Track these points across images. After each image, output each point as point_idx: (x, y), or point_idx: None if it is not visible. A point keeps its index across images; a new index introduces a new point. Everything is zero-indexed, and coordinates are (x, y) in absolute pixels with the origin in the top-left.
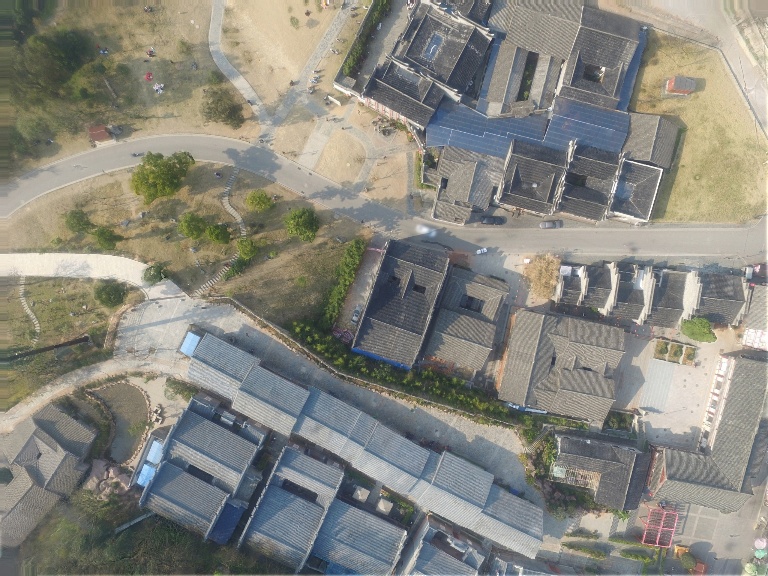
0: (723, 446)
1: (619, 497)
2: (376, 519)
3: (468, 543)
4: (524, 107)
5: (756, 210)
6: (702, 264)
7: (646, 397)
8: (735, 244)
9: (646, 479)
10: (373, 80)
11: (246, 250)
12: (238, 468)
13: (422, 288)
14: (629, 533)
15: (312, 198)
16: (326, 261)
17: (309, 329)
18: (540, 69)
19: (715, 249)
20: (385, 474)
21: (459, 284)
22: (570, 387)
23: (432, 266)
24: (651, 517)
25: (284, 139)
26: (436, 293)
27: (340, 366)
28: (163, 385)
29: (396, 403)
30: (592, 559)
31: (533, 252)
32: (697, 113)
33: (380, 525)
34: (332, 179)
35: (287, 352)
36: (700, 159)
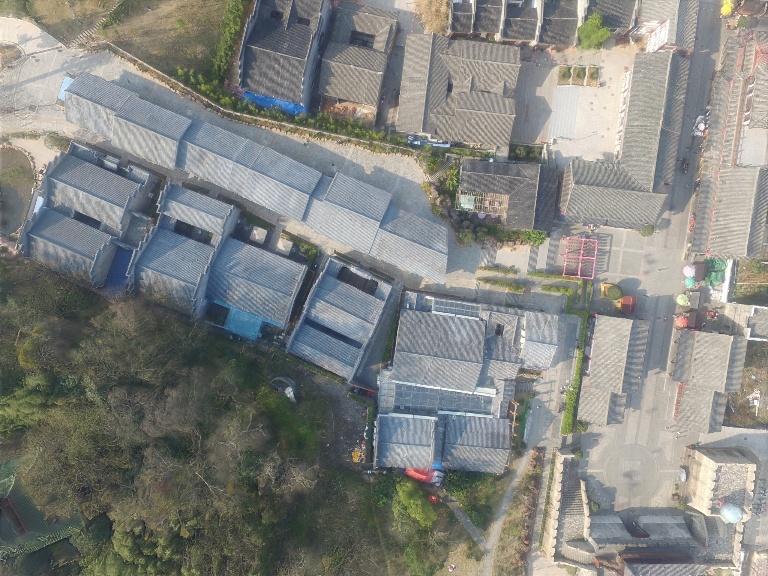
0: (631, 151)
1: (528, 215)
2: (274, 256)
3: (375, 277)
4: None
5: None
6: None
7: (554, 127)
8: None
9: (558, 200)
10: None
11: None
12: (121, 204)
13: (307, 21)
14: (551, 272)
15: None
16: (211, 14)
17: (193, 73)
18: None
19: None
20: (276, 198)
21: (346, 17)
22: (467, 106)
23: None
24: (570, 248)
25: None
26: (318, 17)
27: (228, 107)
28: (43, 137)
29: (288, 139)
30: (512, 296)
31: None
32: None
33: (279, 261)
34: None
35: (171, 95)
36: None
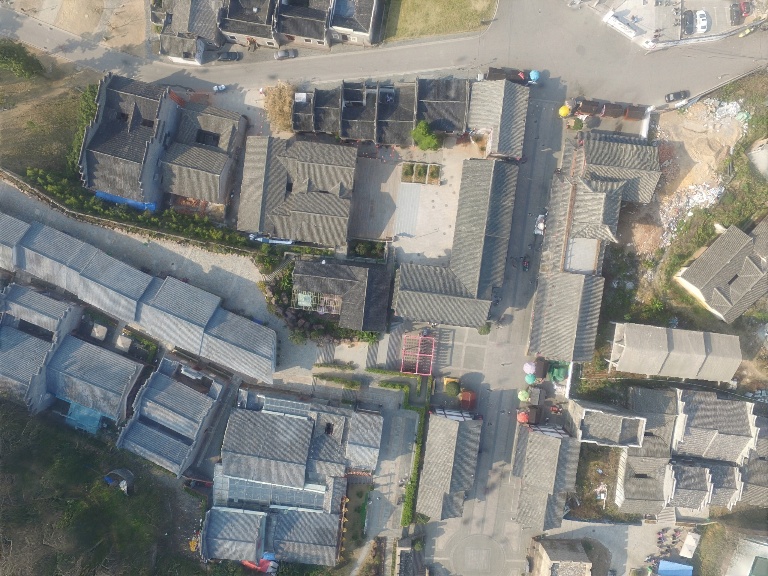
0: (460, 255)
1: (358, 317)
2: (111, 354)
3: (209, 375)
4: None
5: (483, 15)
6: (437, 78)
7: (398, 223)
8: (468, 54)
9: None
10: None
11: None
12: None
13: (151, 122)
14: (393, 366)
15: (55, 53)
16: (67, 111)
17: (43, 172)
18: None
19: (449, 61)
20: (107, 301)
21: (191, 117)
22: (302, 208)
23: (154, 96)
24: (408, 344)
25: None
26: None
27: (75, 206)
28: None
29: (130, 238)
30: (349, 391)
31: (272, 85)
32: None
33: (115, 359)
34: (72, 32)
35: (20, 195)
36: None
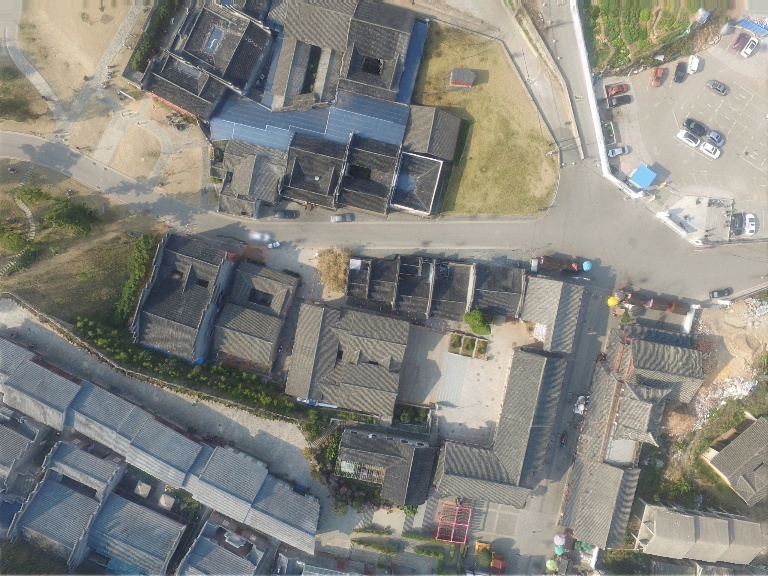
0: (504, 440)
1: (401, 492)
2: (154, 514)
3: (250, 539)
4: (304, 100)
5: (541, 202)
6: (491, 257)
7: (442, 391)
8: (523, 236)
9: (433, 474)
10: (151, 74)
11: (13, 244)
12: (8, 463)
13: (205, 282)
14: (427, 529)
15: (108, 193)
16: (119, 256)
17: (93, 324)
18: (323, 62)
19: (504, 241)
20: (156, 469)
21: (245, 278)
22: (352, 381)
23: (211, 260)
24: (445, 513)
25: (79, 134)
26: (213, 287)
27: (124, 361)
28: None
29: (178, 398)
30: (385, 555)
31: (327, 246)
32: (482, 105)
33: (158, 520)
34: (127, 174)
35: (69, 347)
36: (486, 151)
